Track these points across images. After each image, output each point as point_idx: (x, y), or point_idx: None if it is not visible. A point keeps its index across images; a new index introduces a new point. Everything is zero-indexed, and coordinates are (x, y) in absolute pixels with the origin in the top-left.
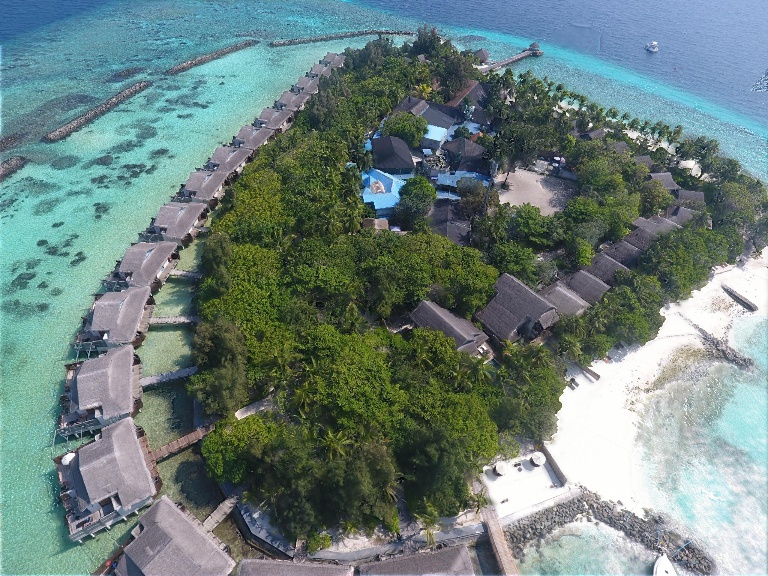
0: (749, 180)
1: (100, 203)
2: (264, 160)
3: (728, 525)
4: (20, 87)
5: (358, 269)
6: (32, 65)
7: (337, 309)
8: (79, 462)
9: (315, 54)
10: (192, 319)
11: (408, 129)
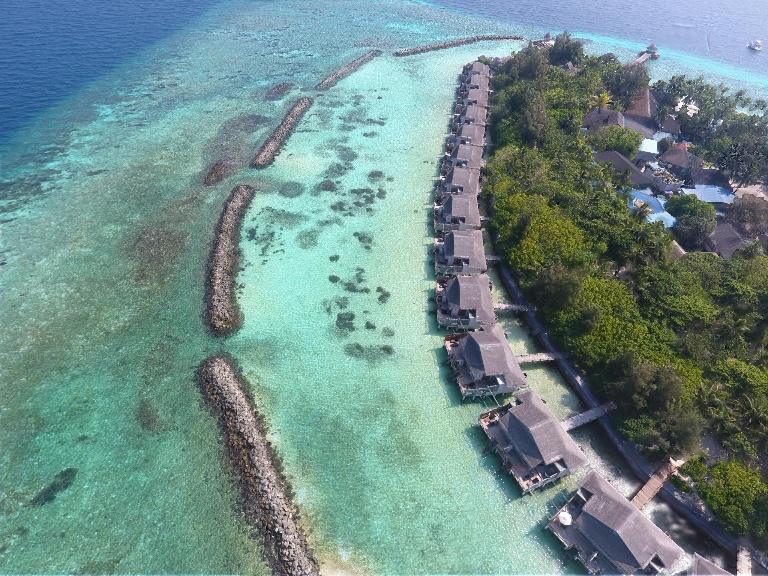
0: None
1: (358, 232)
2: (509, 181)
3: None
4: (186, 109)
5: (708, 297)
6: (180, 84)
7: (731, 342)
8: (605, 524)
9: (445, 63)
10: (554, 356)
11: (628, 143)
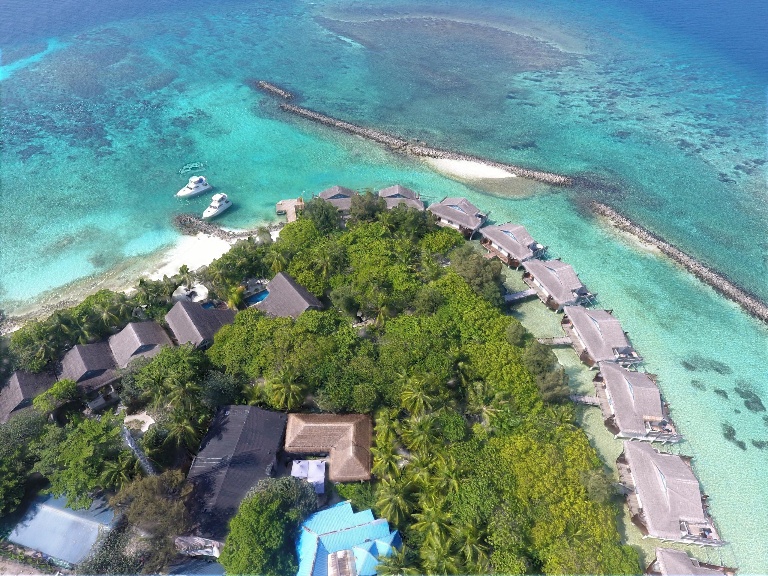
0: None
1: None
2: None
3: (148, 232)
4: None
5: None
6: None
7: None
8: None
9: None
10: None
11: None
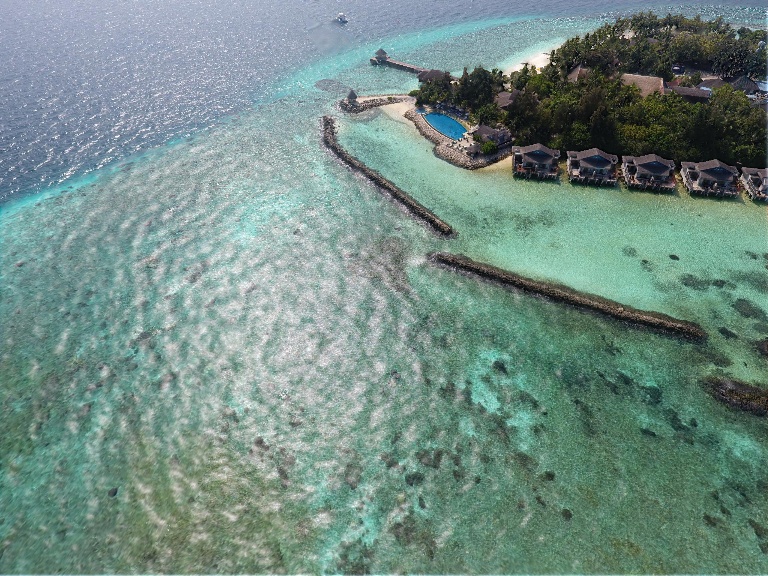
0: (677, 17)
1: None
2: None
3: None
4: None
5: None
6: None
7: None
8: None
9: (470, 187)
10: None
11: None
